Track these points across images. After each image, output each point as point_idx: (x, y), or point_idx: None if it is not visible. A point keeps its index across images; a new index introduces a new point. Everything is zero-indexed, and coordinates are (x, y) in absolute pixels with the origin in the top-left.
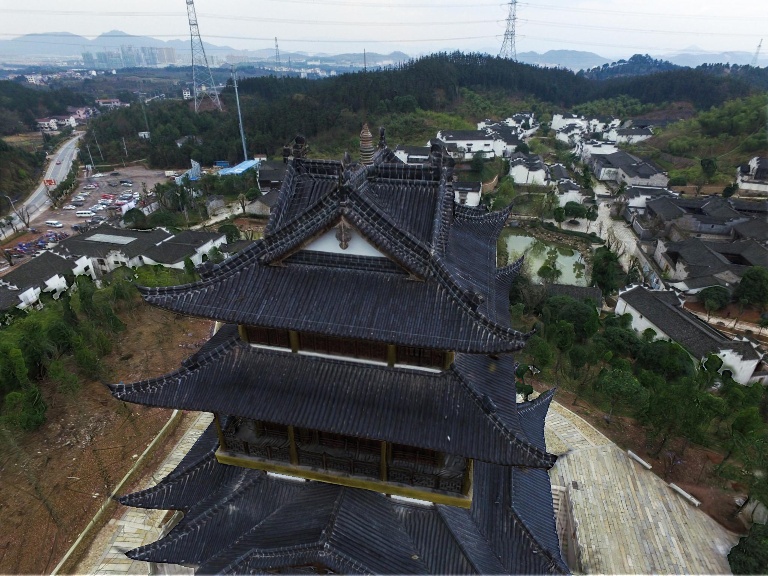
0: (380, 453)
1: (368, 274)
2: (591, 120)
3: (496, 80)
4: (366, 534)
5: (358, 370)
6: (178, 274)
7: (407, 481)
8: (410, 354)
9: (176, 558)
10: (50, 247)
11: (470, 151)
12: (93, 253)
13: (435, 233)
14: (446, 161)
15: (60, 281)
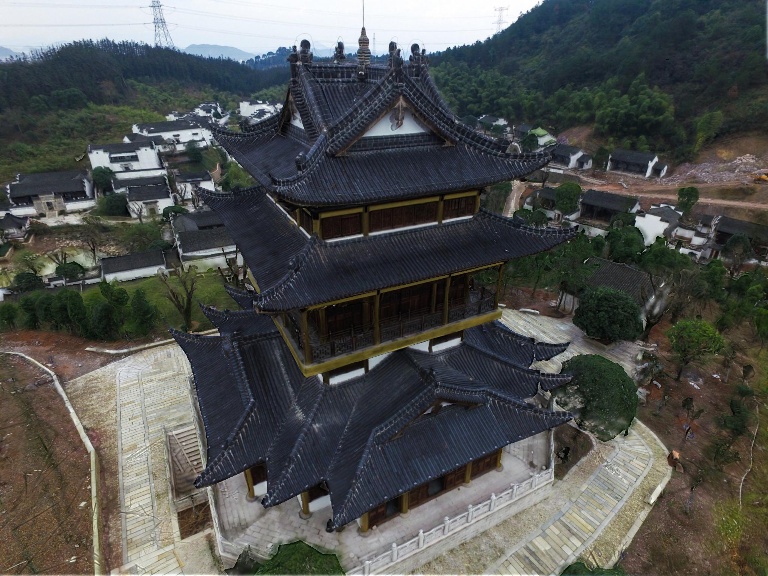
0: (427, 312)
1: (412, 150)
2: (276, 105)
3: (164, 71)
4: (441, 376)
5: (420, 233)
6: None
7: (460, 317)
8: (452, 208)
9: (299, 488)
10: None
11: (180, 142)
12: None
13: None
14: (423, 59)
15: None
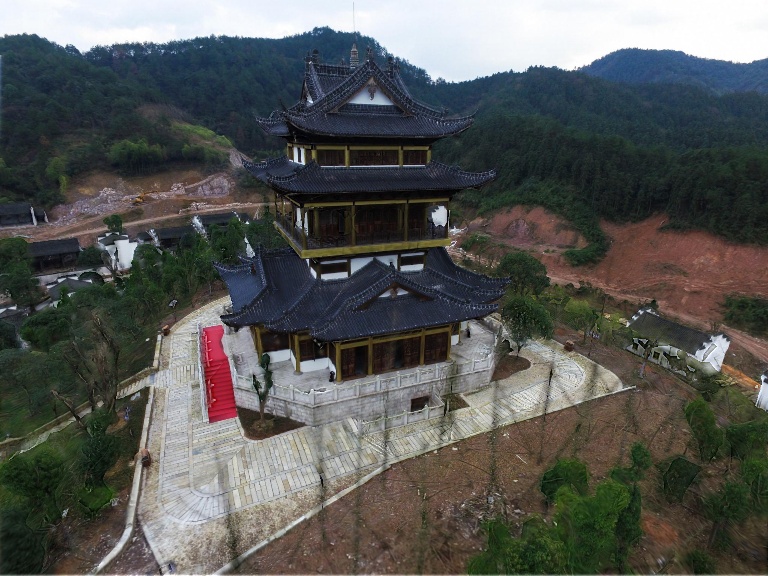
0: None
1: None
2: None
3: None
4: None
5: None
6: None
7: None
8: None
9: None
10: None
11: None
12: None
13: None
14: None
15: None
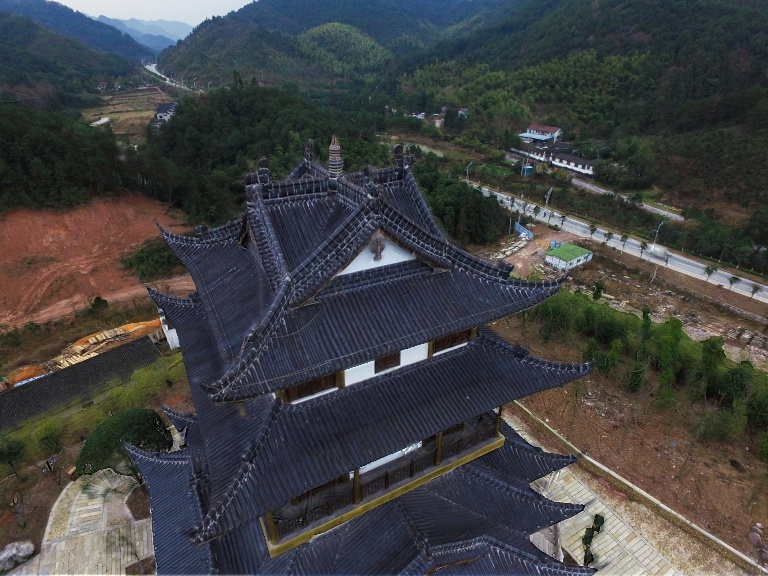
0: None
1: None
2: None
3: None
4: None
5: None
6: None
7: None
8: None
9: None
10: None
11: None
12: None
13: None
14: None
15: None
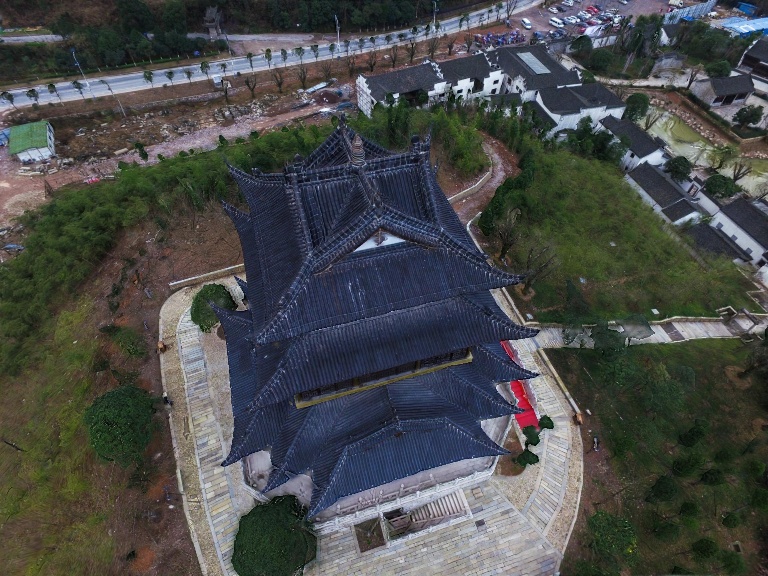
0: None
1: None
2: None
3: None
4: None
5: None
6: (509, 130)
7: None
8: None
9: None
10: (489, 50)
11: None
12: (509, 70)
13: (324, 245)
14: None
15: (469, 85)
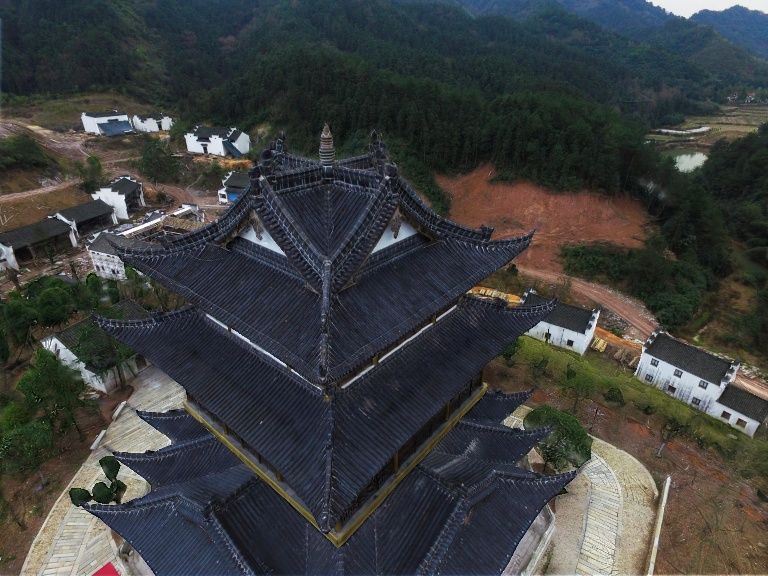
0: None
1: None
2: None
3: None
4: None
5: None
6: None
7: None
8: None
9: None
10: None
11: None
12: None
13: None
14: None
15: None
